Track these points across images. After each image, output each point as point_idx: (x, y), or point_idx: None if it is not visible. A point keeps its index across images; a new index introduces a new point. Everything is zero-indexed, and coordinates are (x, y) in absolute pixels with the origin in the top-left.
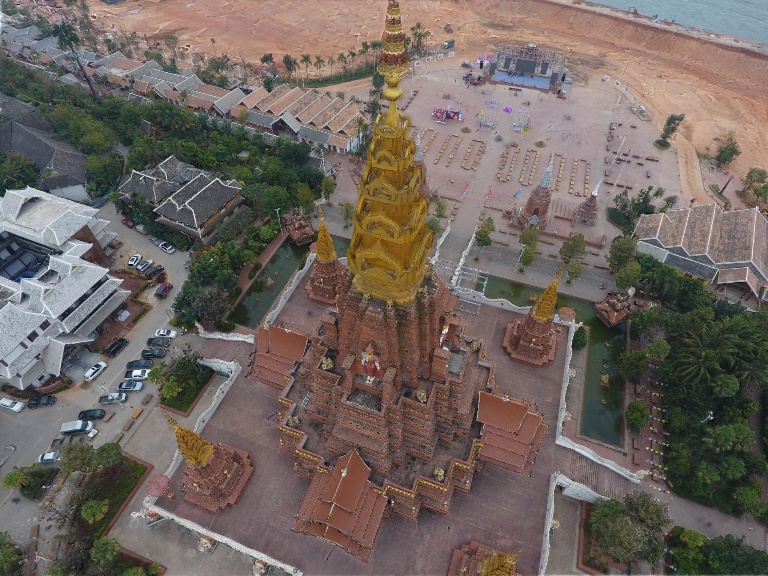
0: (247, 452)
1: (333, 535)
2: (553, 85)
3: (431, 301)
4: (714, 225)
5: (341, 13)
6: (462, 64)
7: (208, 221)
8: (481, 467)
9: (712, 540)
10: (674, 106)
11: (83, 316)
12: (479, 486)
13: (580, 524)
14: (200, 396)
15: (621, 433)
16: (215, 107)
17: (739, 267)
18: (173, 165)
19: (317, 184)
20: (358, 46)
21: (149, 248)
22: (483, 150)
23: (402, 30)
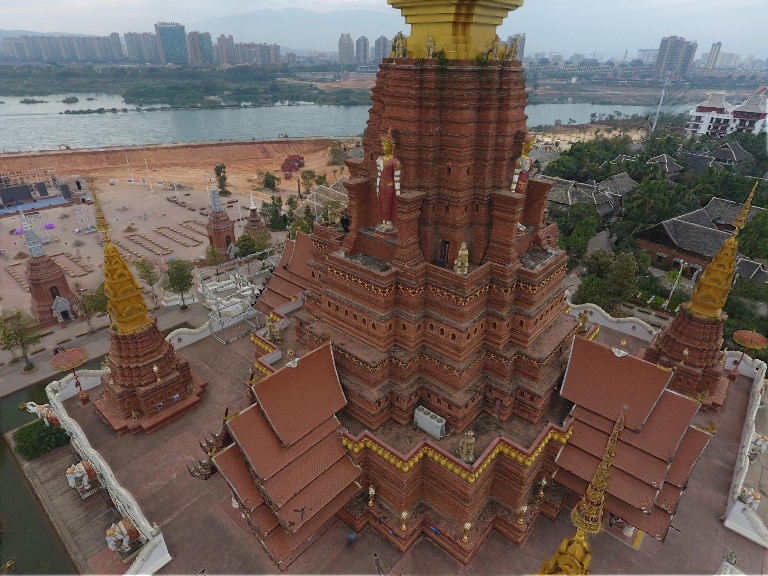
0: None
1: None
2: (70, 199)
3: None
4: None
5: None
6: None
7: None
8: None
9: None
10: (194, 178)
11: None
12: None
13: None
14: None
15: None
16: None
17: None
18: None
19: None
20: None
21: None
22: (77, 256)
23: None
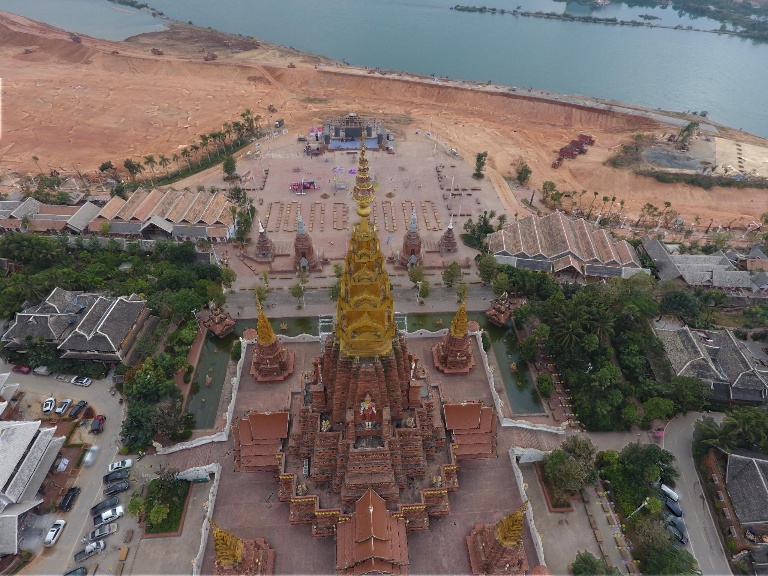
0: (262, 538)
1: (379, 565)
2: (381, 144)
3: (402, 346)
4: (537, 230)
5: (161, 108)
6: (298, 139)
7: (124, 341)
8: (460, 466)
9: (622, 452)
10: (475, 145)
11: (26, 479)
12: (463, 482)
13: (540, 479)
14: (185, 510)
15: (539, 402)
16: (69, 226)
17: (564, 256)
18: (61, 296)
19: (213, 276)
20: (197, 139)
21: (59, 388)
22: (347, 210)
23: (229, 116)
